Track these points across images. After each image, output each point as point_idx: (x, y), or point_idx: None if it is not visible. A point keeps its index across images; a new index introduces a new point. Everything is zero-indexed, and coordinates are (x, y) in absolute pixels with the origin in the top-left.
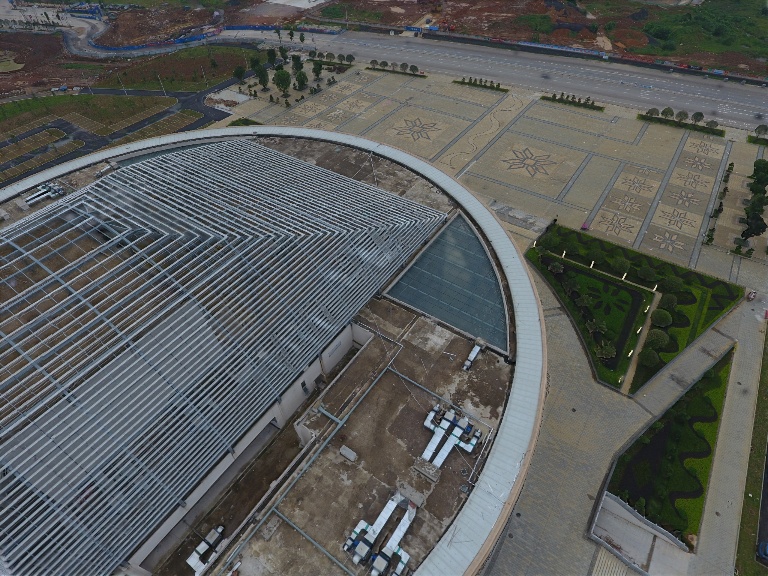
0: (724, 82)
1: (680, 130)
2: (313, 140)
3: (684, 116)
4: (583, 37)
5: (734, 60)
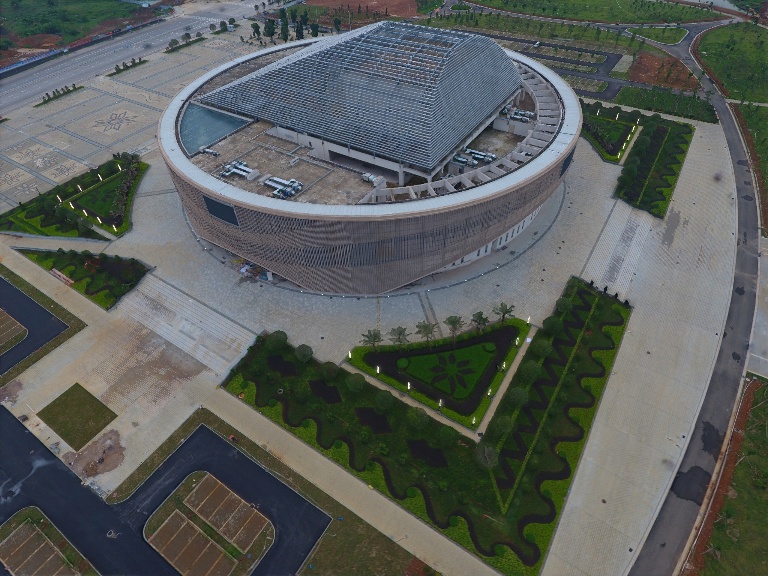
0: (142, 29)
1: (192, 46)
2: (208, 82)
3: (186, 37)
4: (10, 55)
5: (115, 23)
